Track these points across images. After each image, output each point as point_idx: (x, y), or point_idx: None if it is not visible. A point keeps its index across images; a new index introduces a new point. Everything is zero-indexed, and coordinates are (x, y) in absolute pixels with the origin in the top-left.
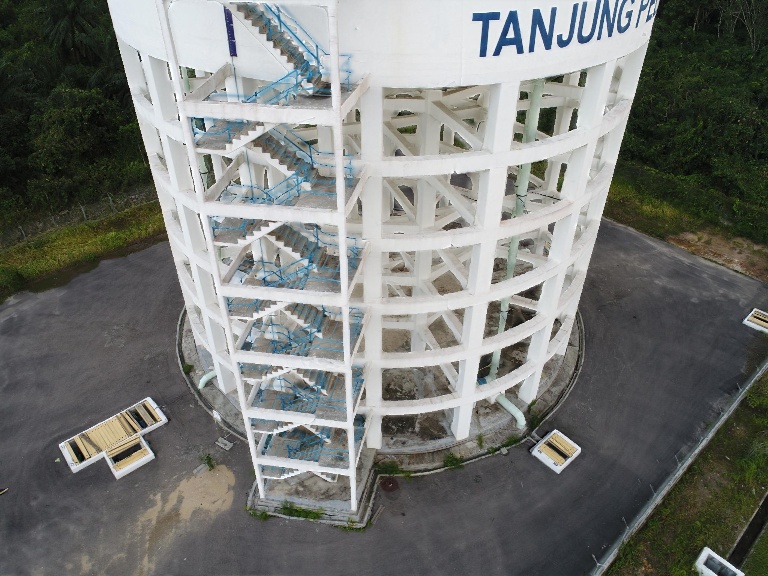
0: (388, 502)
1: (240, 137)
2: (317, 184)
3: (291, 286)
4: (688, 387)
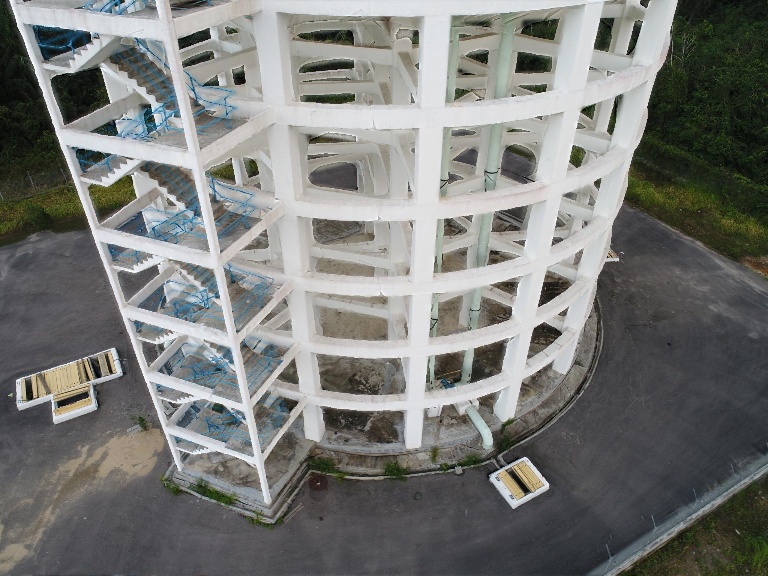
0: (309, 502)
1: None
2: (195, 122)
3: None
4: (711, 436)
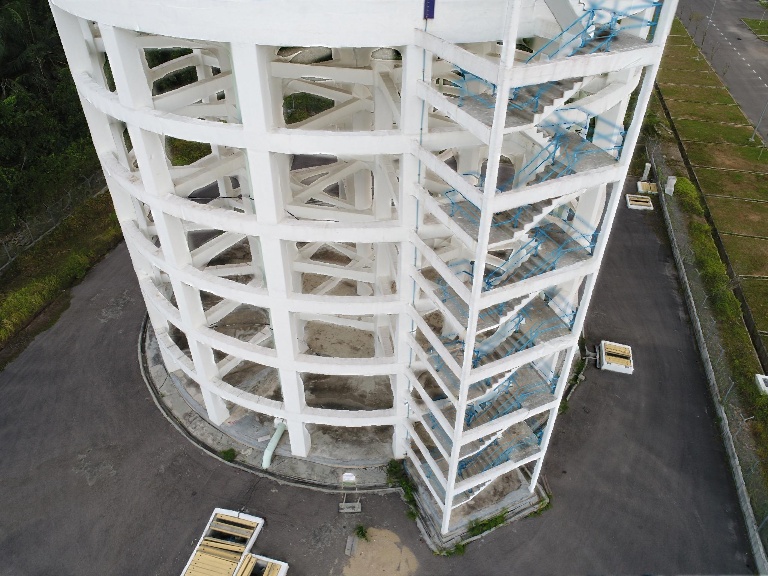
0: (544, 469)
1: (553, 102)
2: None
3: (544, 270)
4: (642, 268)
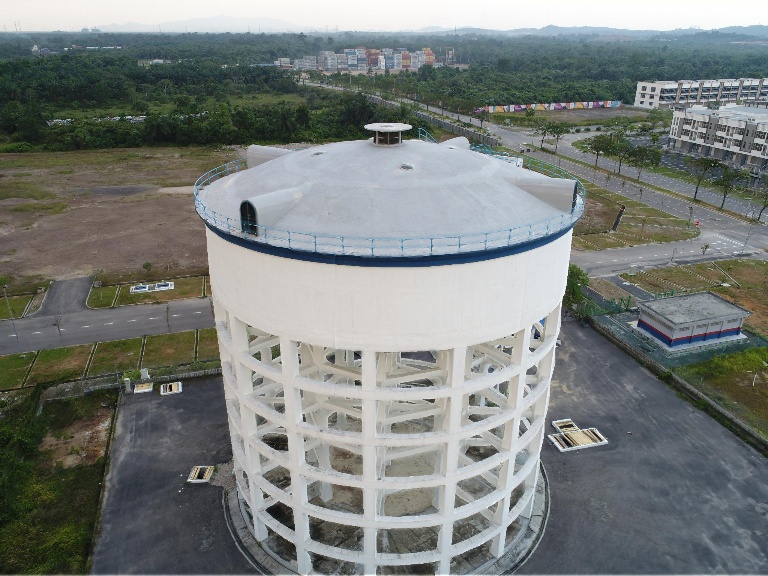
0: None
1: None
2: None
3: None
4: None
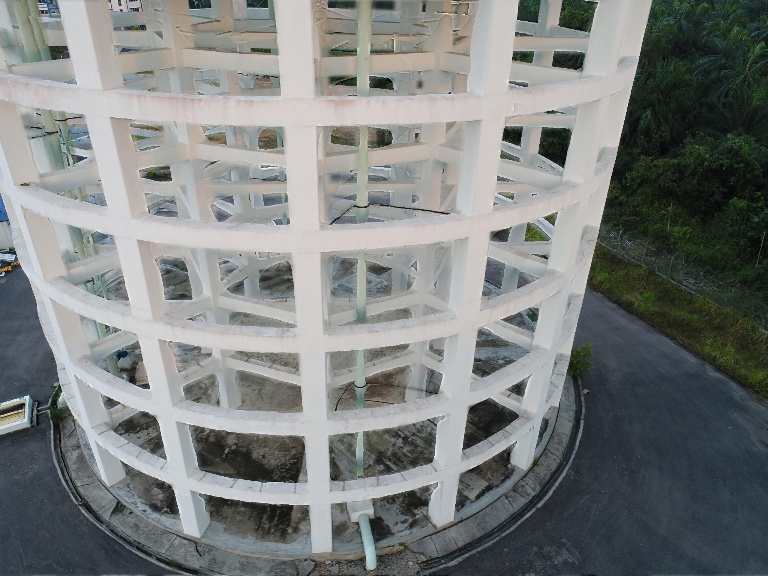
0: None
1: None
2: None
3: None
4: None
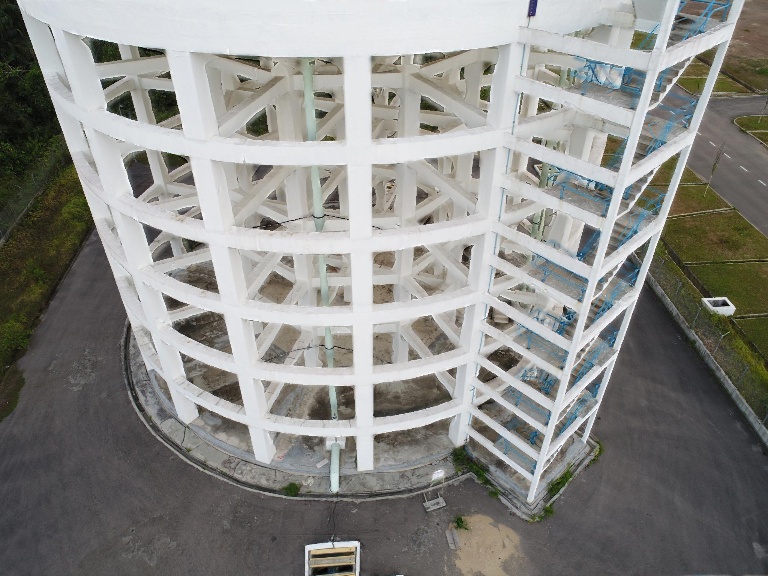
0: None
1: (672, 81)
2: None
3: (632, 234)
4: None
